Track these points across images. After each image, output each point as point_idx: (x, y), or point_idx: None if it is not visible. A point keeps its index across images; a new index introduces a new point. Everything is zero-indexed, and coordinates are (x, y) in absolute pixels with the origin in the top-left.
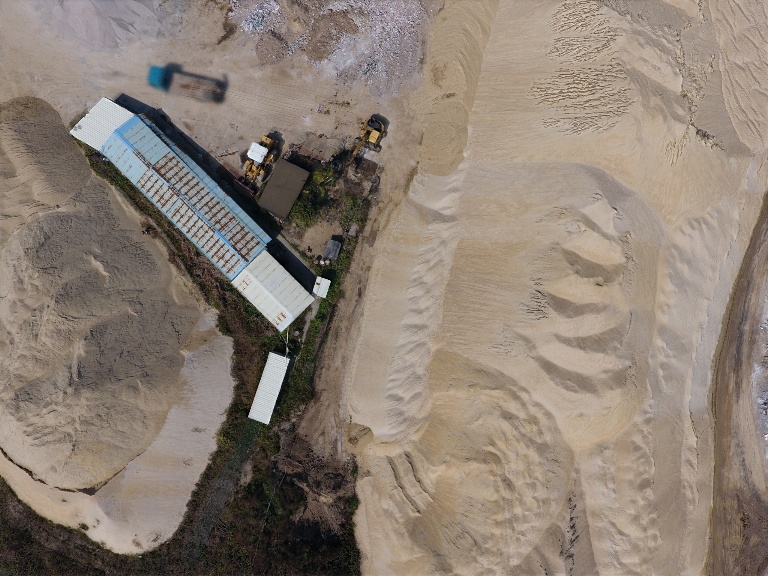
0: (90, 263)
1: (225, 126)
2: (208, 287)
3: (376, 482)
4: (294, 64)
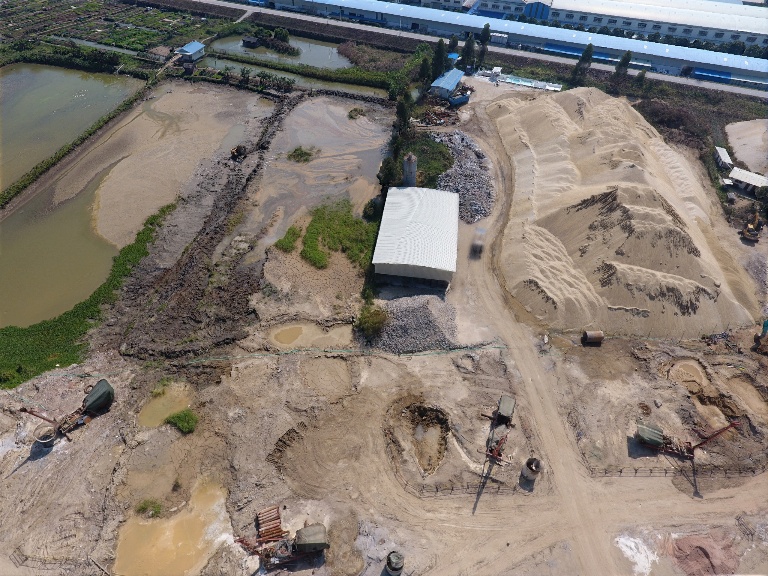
0: None
1: None
2: None
3: None
4: None
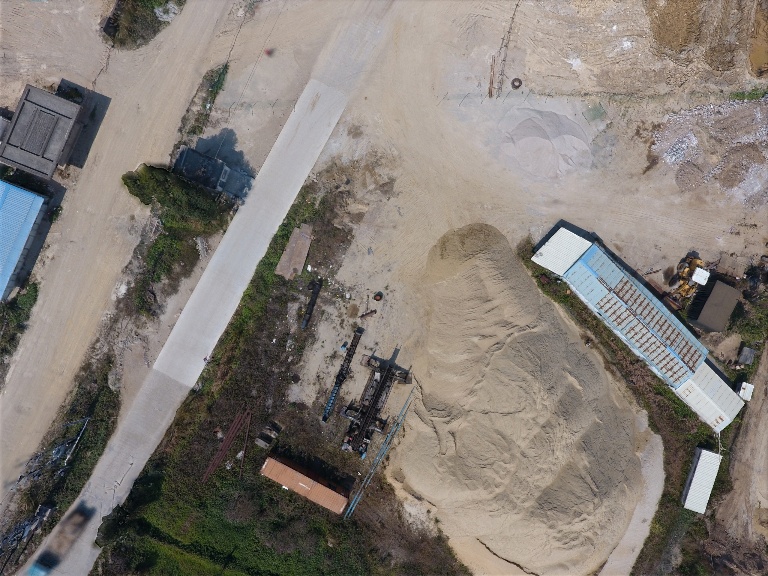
0: (567, 379)
1: (650, 247)
2: (641, 391)
3: None
4: (708, 191)
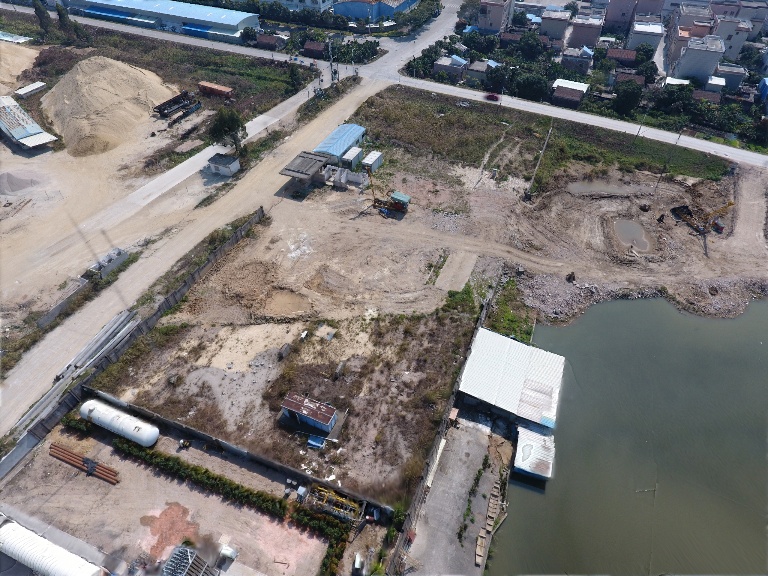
0: None
1: None
2: (37, 111)
3: (8, 72)
4: None
